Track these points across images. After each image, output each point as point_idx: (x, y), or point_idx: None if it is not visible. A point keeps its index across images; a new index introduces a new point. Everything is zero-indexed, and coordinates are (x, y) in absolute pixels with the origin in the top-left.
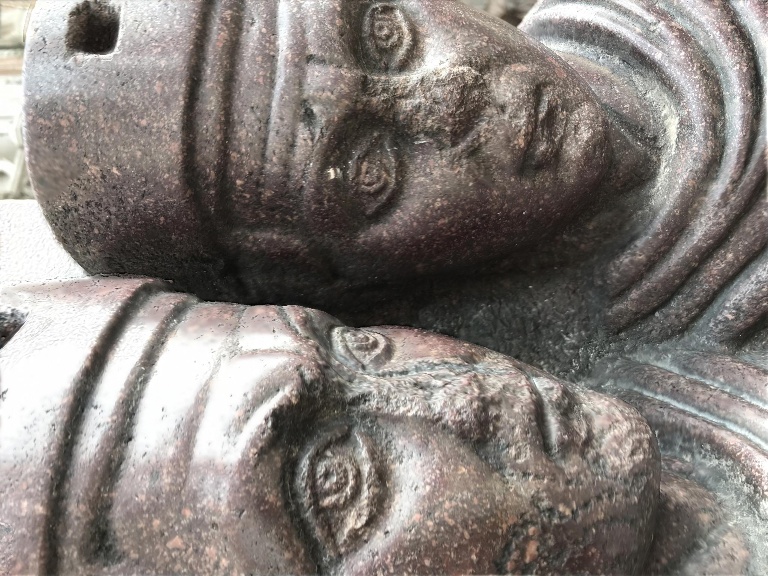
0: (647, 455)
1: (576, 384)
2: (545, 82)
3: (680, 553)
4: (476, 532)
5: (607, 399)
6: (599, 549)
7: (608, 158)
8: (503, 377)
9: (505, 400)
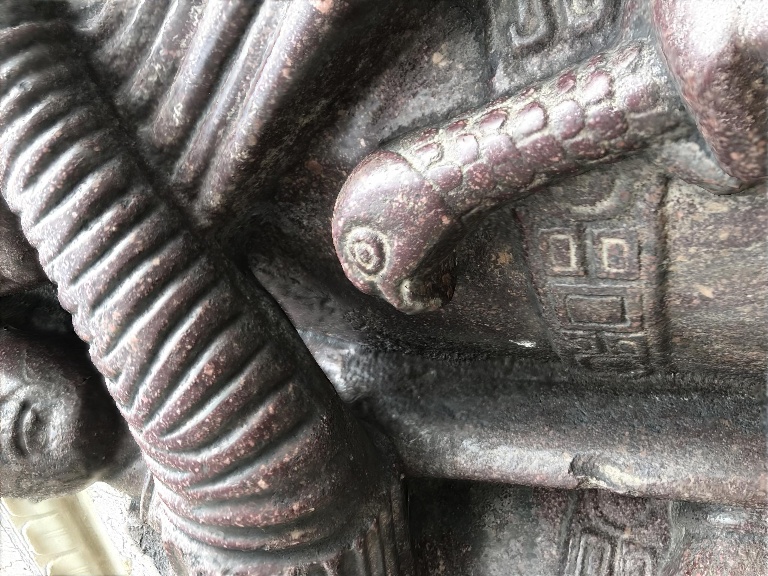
0: (69, 450)
1: (59, 402)
2: None
3: (132, 453)
4: (5, 482)
5: (62, 418)
6: (57, 480)
7: (37, 274)
8: (5, 423)
9: (1, 439)
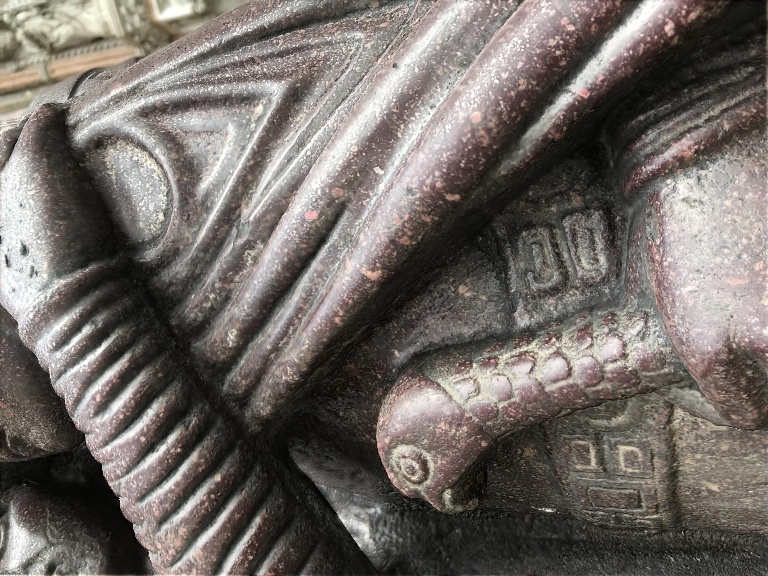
0: None
1: (84, 562)
2: (0, 426)
3: None
4: None
5: None
6: None
7: None
8: None
9: None
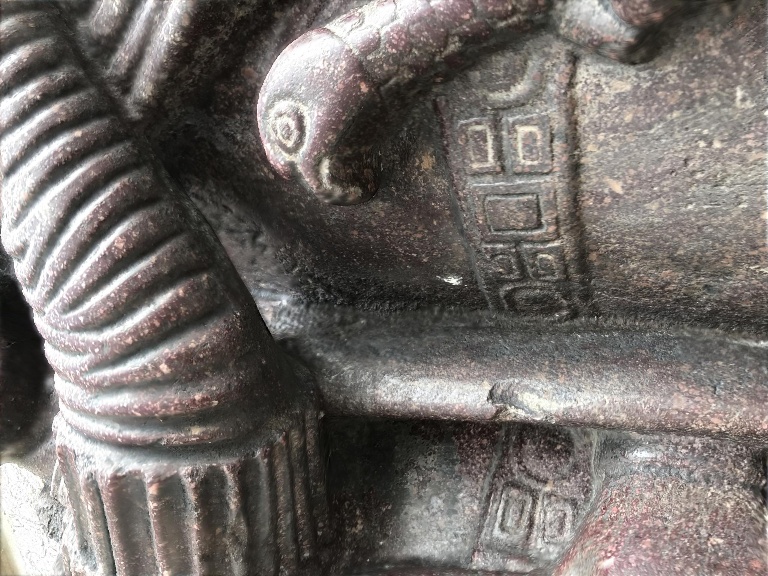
0: None
1: None
2: None
3: (50, 426)
4: None
5: None
6: None
7: None
8: None
9: None
